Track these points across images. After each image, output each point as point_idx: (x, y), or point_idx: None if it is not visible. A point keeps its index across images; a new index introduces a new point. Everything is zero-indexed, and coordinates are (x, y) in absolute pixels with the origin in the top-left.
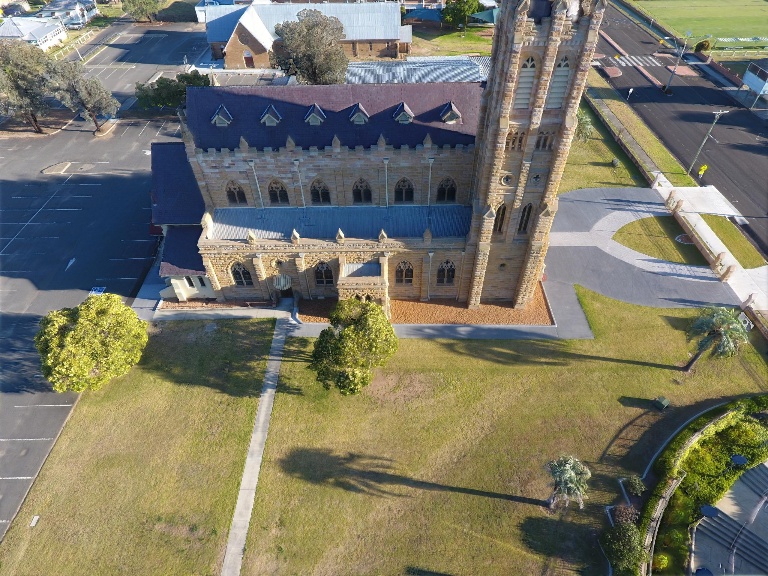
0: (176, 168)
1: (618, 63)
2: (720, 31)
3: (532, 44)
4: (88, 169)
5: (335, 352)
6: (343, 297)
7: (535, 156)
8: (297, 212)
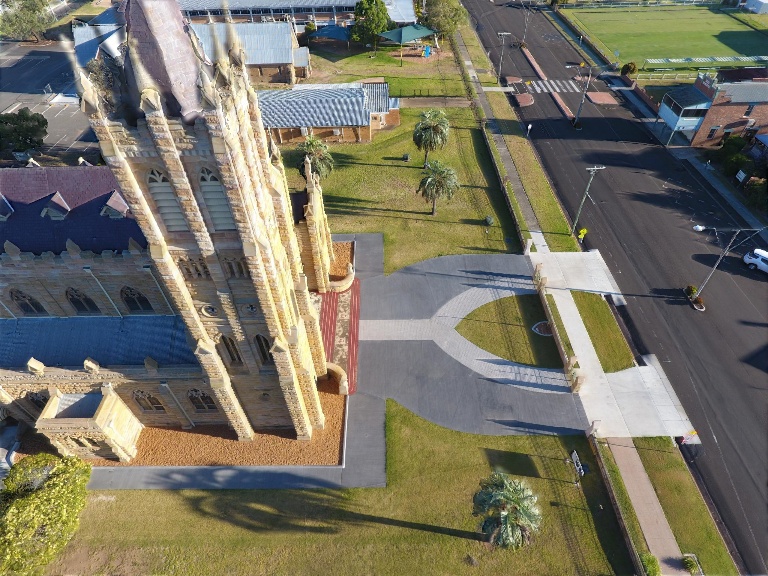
0: None
1: (533, 89)
2: (656, 49)
3: (140, 154)
4: None
5: None
6: (55, 440)
7: (233, 285)
8: (6, 325)
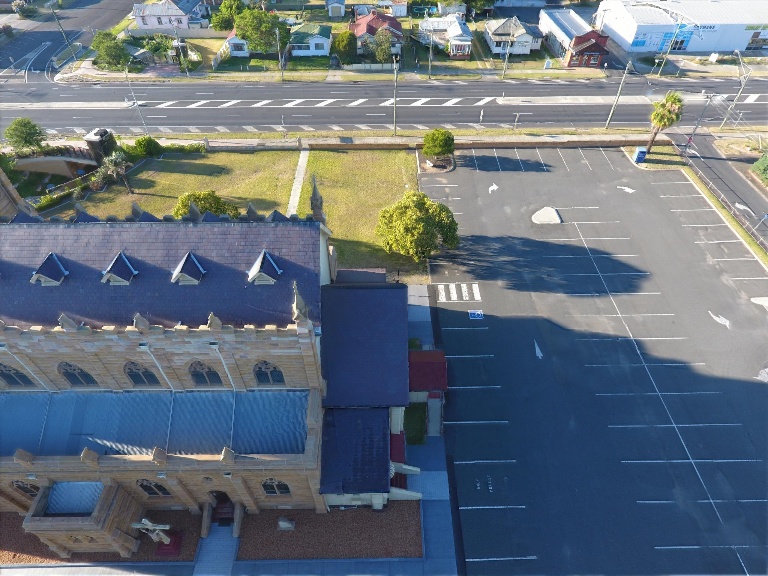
0: None
1: None
2: None
3: None
4: None
5: (223, 210)
6: None
7: None
8: None
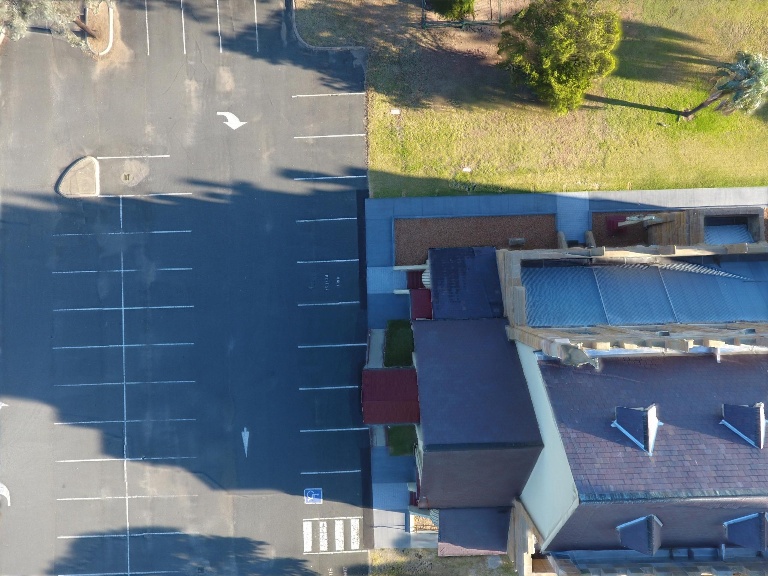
0: (469, 470)
1: None
2: None
3: None
4: (141, 180)
5: None
6: None
7: None
8: None
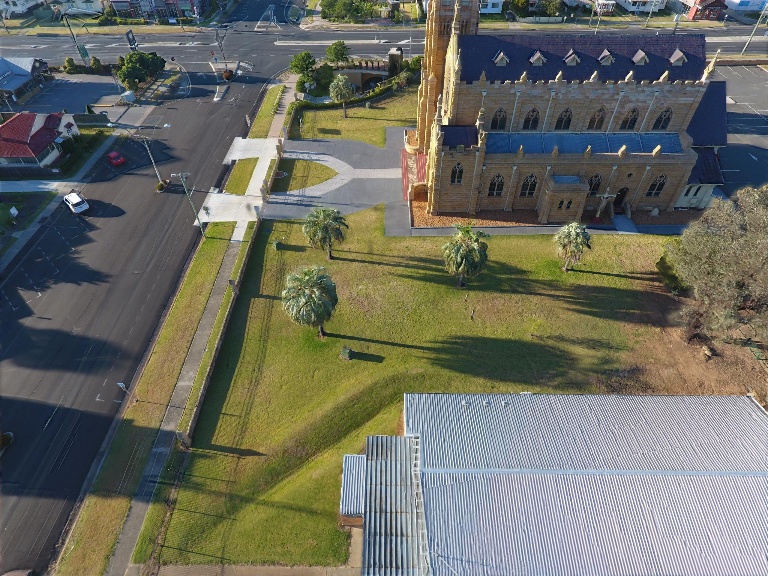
0: None
1: None
2: None
3: None
4: None
5: None
6: None
7: None
8: None
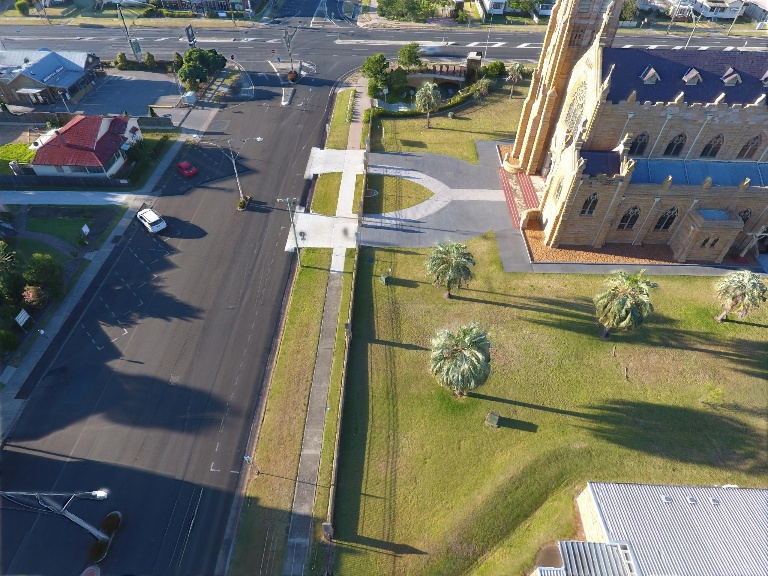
0: None
1: None
2: None
3: None
4: None
5: None
6: None
7: None
8: None
